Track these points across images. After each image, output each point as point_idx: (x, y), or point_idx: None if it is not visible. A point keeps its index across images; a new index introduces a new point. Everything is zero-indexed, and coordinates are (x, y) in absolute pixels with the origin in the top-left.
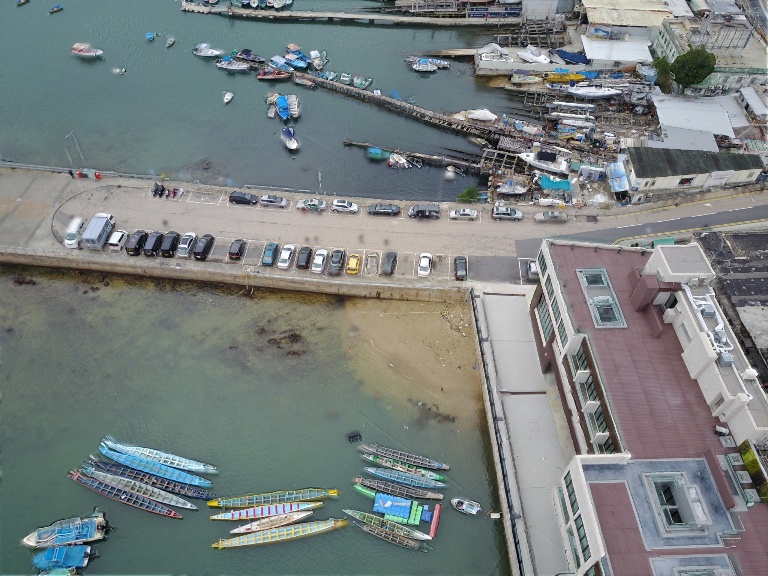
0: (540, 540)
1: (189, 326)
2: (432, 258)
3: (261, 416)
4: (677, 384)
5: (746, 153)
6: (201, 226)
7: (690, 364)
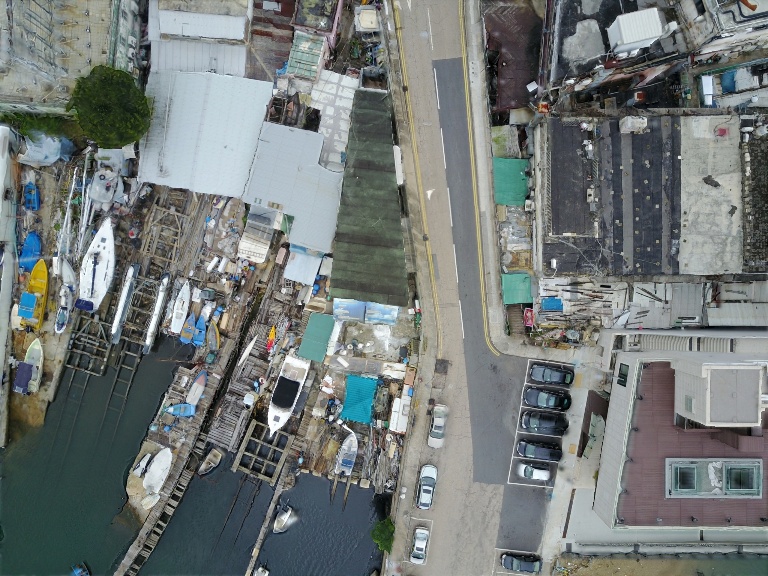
0: None
1: None
2: None
3: None
4: None
5: None
6: None
7: None
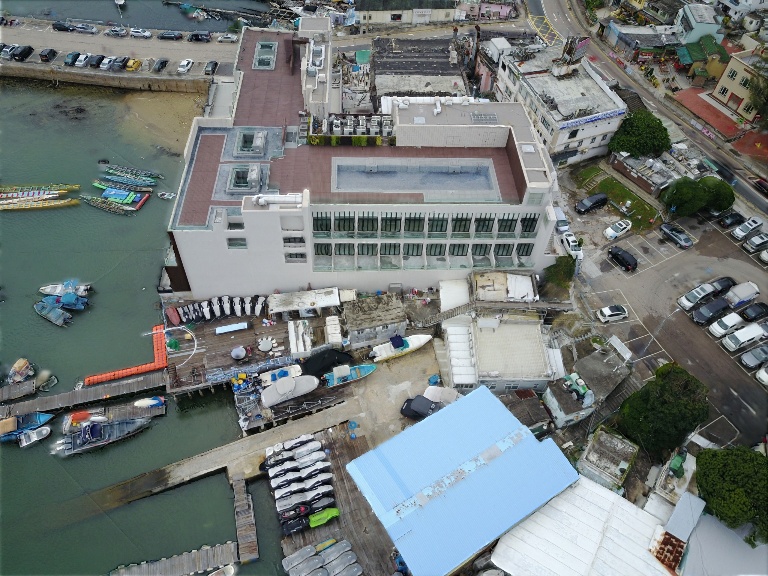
0: None
1: (4, 103)
2: (193, 63)
3: (41, 151)
4: (290, 96)
5: (459, 6)
6: (26, 43)
7: None
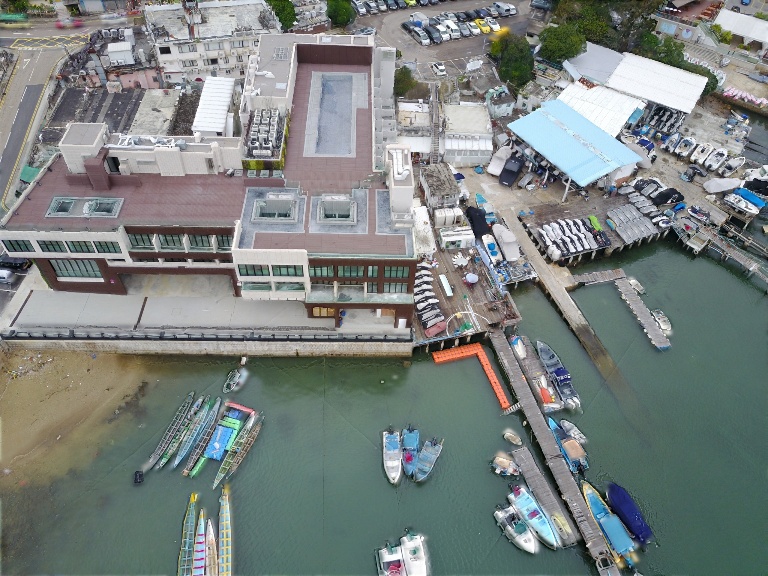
0: (272, 324)
1: None
2: None
3: None
4: (186, 185)
5: None
6: None
7: (173, 171)
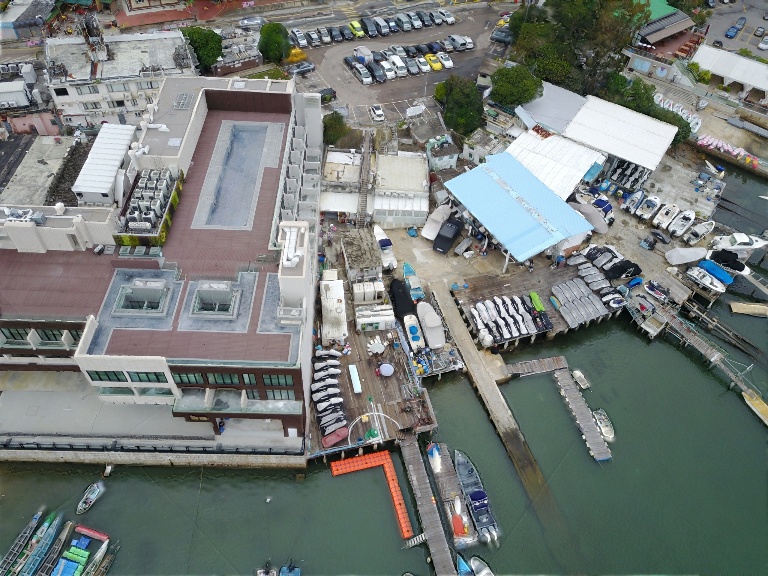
0: (142, 429)
1: None
2: None
3: None
4: (45, 265)
5: None
6: None
7: (31, 248)
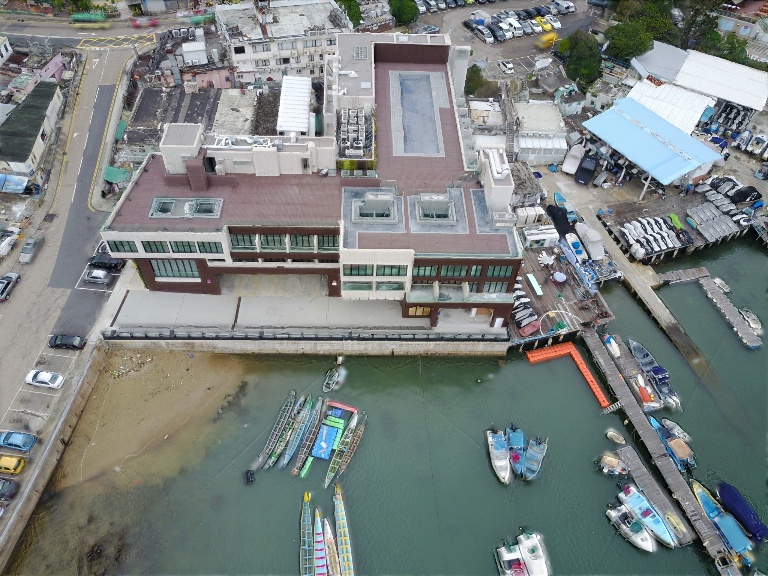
0: (368, 324)
1: None
2: None
3: None
4: (282, 185)
5: (24, 92)
6: None
7: (269, 171)
